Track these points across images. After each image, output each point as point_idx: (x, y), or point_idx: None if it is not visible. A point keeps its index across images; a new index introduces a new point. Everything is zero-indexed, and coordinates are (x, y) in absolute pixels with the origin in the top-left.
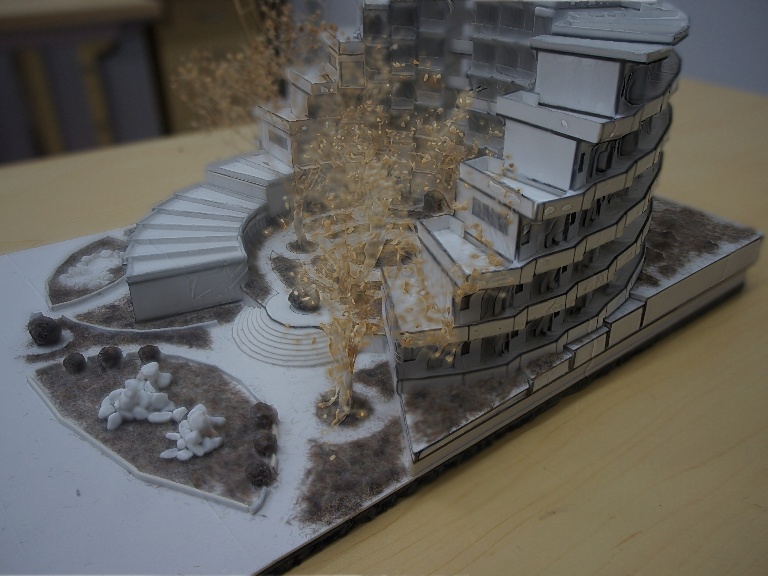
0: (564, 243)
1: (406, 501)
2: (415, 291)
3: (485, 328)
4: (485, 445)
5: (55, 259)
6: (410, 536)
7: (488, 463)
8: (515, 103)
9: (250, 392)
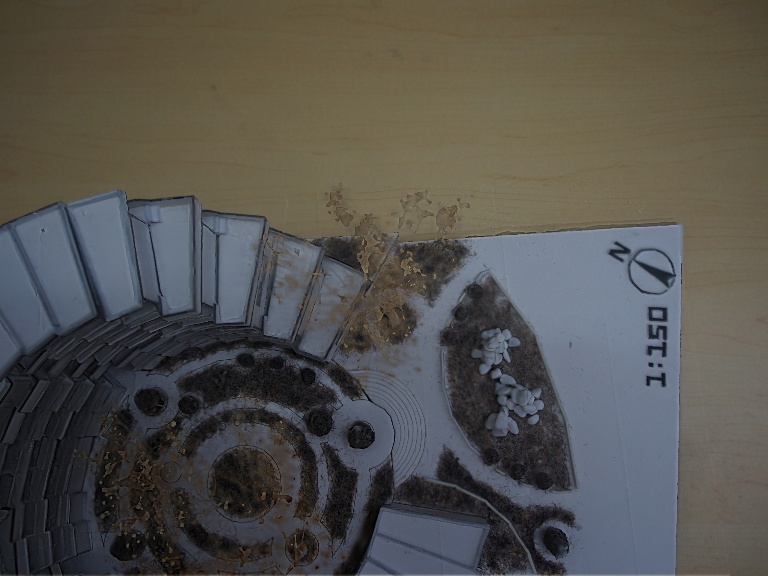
0: None
1: None
2: None
3: None
4: None
5: None
6: None
7: None
8: None
9: None
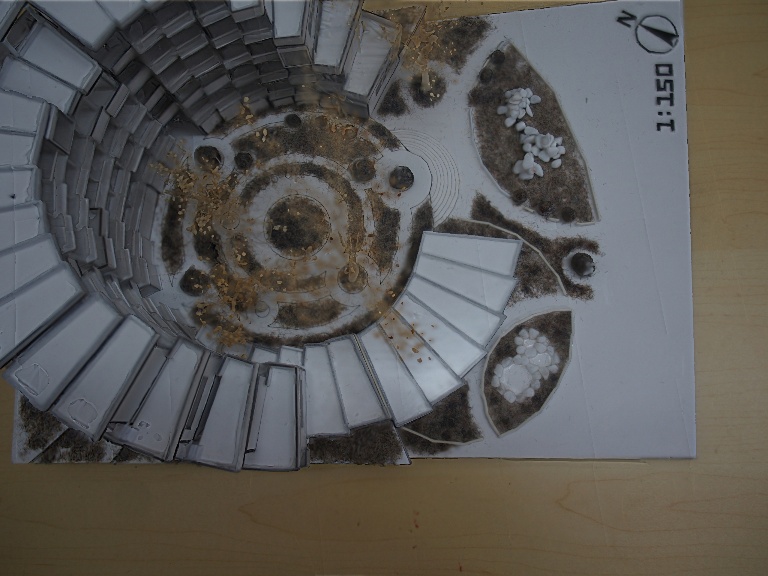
0: None
1: None
2: None
3: None
4: None
5: (555, 416)
6: (441, 6)
7: None
8: None
9: None
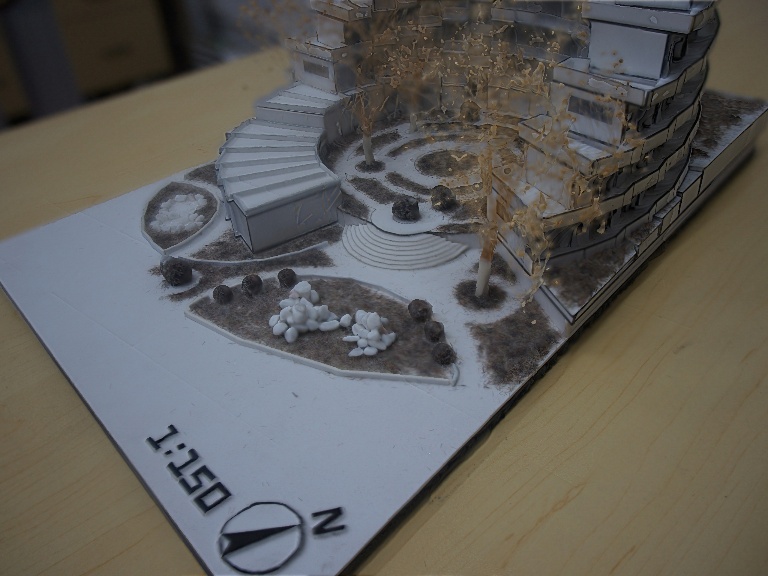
0: (655, 126)
1: (563, 358)
2: (570, 177)
3: (603, 206)
4: (606, 307)
5: (133, 210)
6: (580, 383)
7: (613, 320)
8: (602, 6)
9: (394, 294)
